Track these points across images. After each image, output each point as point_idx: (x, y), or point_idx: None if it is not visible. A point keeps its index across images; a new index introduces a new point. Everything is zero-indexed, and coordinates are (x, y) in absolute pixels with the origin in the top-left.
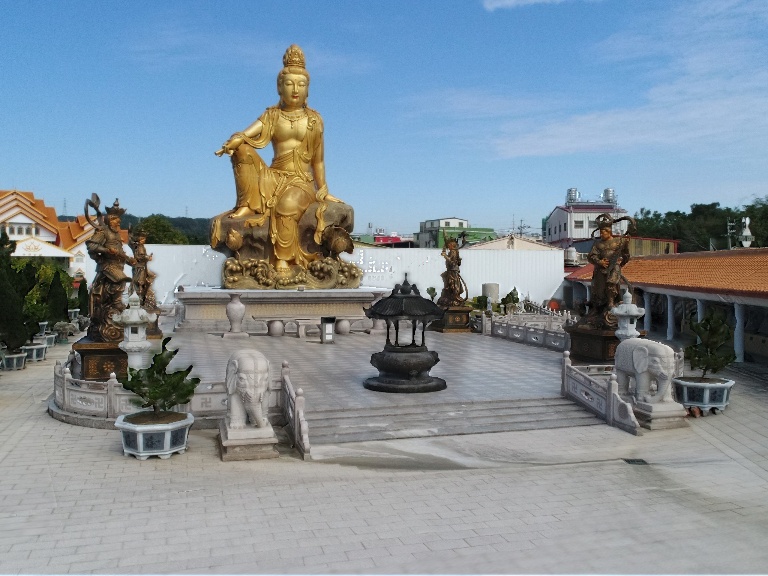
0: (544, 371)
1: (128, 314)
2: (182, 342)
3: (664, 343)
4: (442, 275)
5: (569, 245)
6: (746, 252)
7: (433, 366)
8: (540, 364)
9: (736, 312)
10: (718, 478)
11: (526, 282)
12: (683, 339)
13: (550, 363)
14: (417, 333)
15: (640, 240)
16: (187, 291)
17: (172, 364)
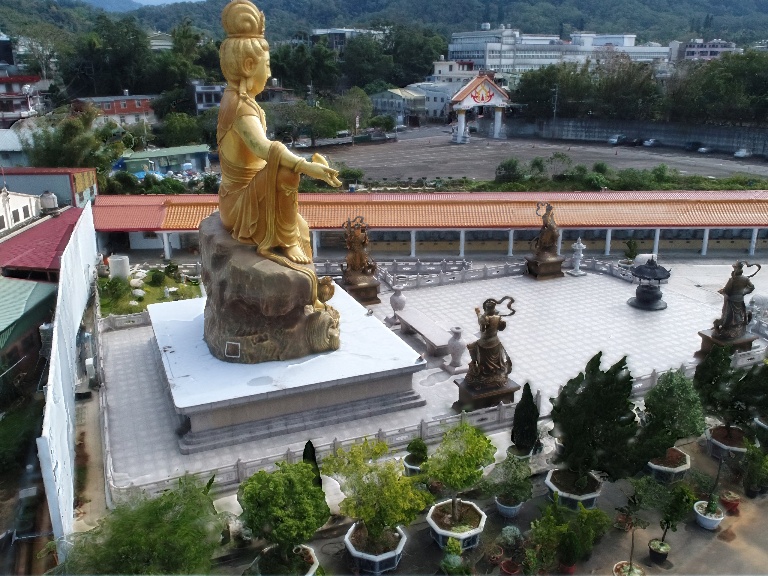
0: (571, 284)
1: (758, 308)
2: (516, 382)
3: (431, 259)
4: (350, 258)
5: (47, 191)
6: (472, 202)
7: (585, 301)
8: (546, 284)
9: (512, 234)
10: (706, 280)
11: (91, 245)
12: (417, 254)
13: (540, 282)
14: (390, 310)
15: (83, 173)
16: (402, 360)
17: (640, 360)
